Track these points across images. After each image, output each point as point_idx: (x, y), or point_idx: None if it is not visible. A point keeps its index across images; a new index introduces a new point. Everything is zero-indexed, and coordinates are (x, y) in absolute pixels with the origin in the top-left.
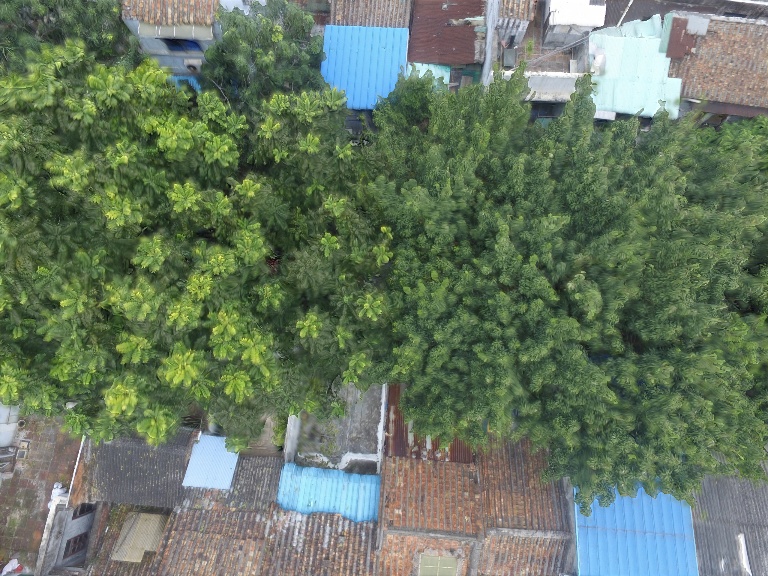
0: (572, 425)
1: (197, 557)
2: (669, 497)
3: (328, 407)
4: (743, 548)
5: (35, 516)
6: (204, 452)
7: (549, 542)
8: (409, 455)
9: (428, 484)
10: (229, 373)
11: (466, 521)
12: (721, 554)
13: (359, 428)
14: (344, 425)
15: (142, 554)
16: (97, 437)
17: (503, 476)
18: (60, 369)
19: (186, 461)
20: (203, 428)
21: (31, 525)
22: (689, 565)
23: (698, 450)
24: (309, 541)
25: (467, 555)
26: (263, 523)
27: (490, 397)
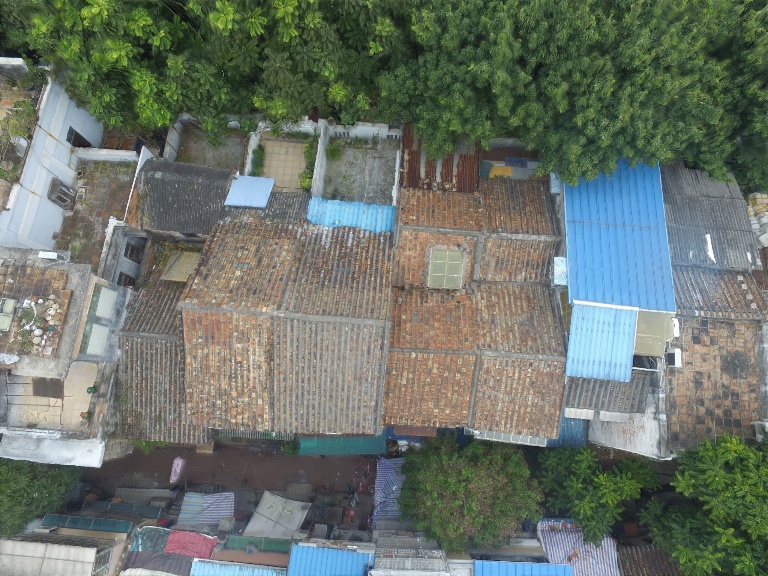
0: (561, 85)
1: (239, 248)
2: (646, 201)
3: (354, 103)
4: (709, 244)
5: (93, 244)
6: (242, 185)
7: (542, 247)
8: (421, 186)
9: (438, 204)
10: (281, 1)
11: (471, 224)
12: (690, 248)
13: (376, 189)
14: (362, 188)
15: (187, 276)
16: (159, 118)
17: (503, 204)
18: (137, 24)
19: (227, 190)
20: (240, 172)
21: (90, 251)
22: (661, 249)
23: (664, 82)
24: (335, 242)
25: (471, 251)
26: (295, 230)
27: (493, 53)
